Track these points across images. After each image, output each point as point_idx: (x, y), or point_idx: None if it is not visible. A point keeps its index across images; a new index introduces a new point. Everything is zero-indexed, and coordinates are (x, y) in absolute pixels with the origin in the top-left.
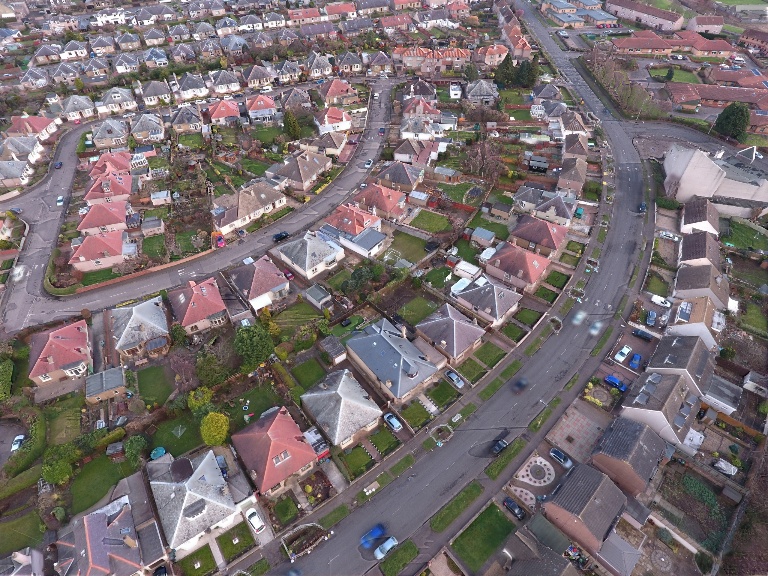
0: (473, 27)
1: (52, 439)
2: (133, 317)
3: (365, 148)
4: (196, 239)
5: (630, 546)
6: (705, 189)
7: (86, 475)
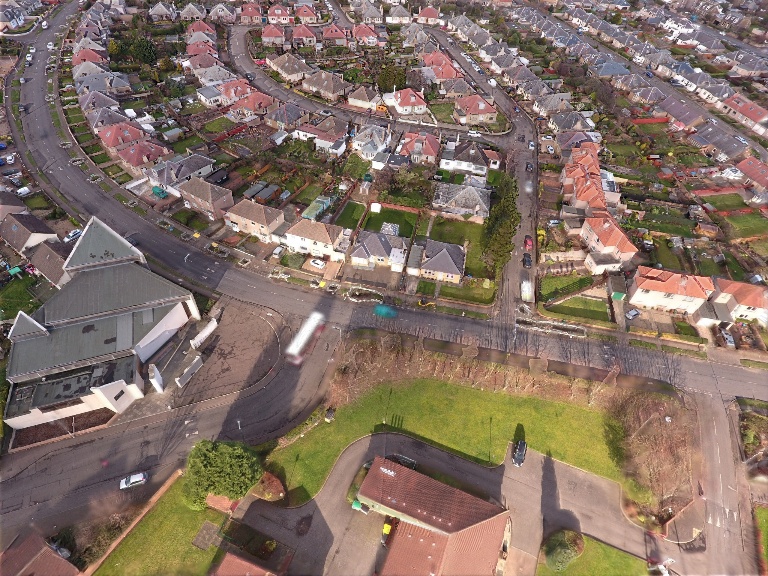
0: None
1: None
2: None
3: (357, 117)
4: None
5: None
6: None
7: None
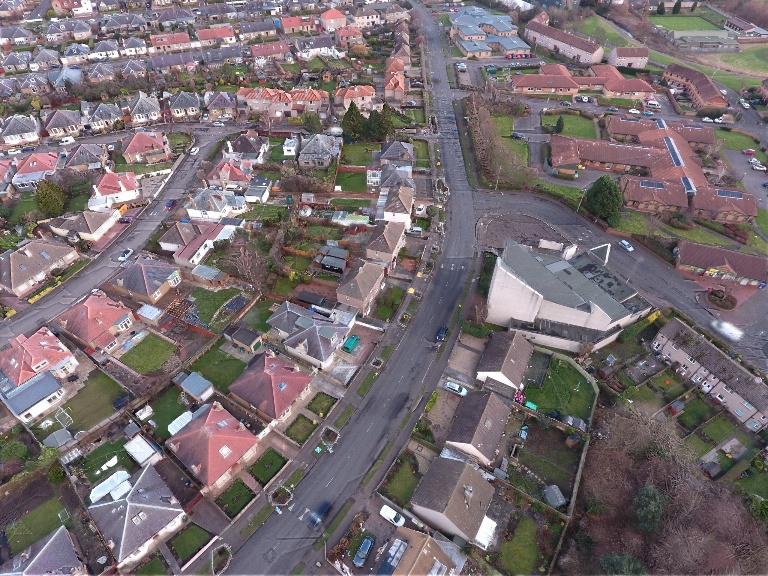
0: (359, 57)
1: None
2: None
3: (137, 229)
4: None
5: None
6: (522, 312)
7: None
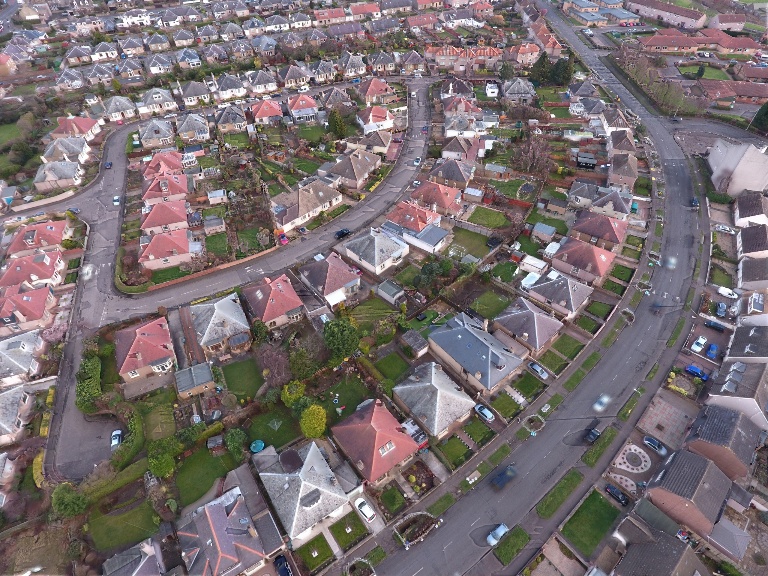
0: (499, 26)
1: (149, 434)
2: (216, 313)
3: (411, 146)
4: (262, 237)
5: (739, 529)
6: (756, 183)
7: (189, 468)
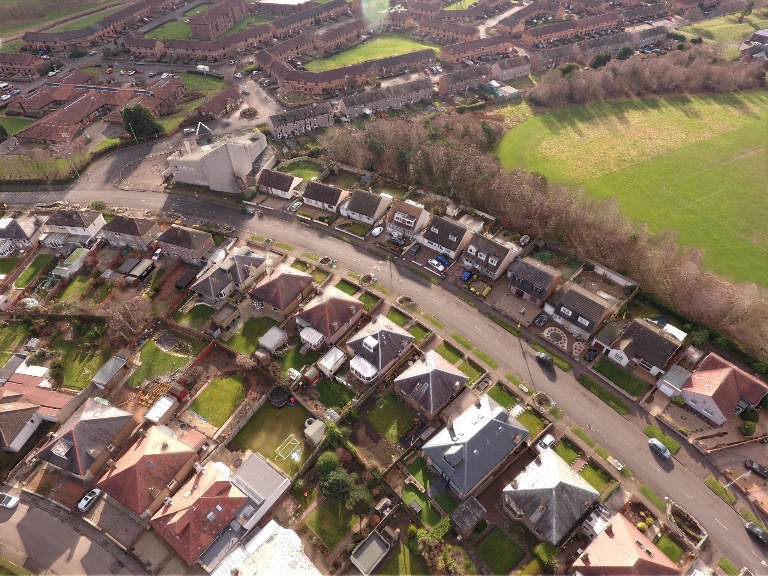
0: None
1: None
2: None
3: None
4: None
5: (598, 294)
6: (247, 166)
7: None
